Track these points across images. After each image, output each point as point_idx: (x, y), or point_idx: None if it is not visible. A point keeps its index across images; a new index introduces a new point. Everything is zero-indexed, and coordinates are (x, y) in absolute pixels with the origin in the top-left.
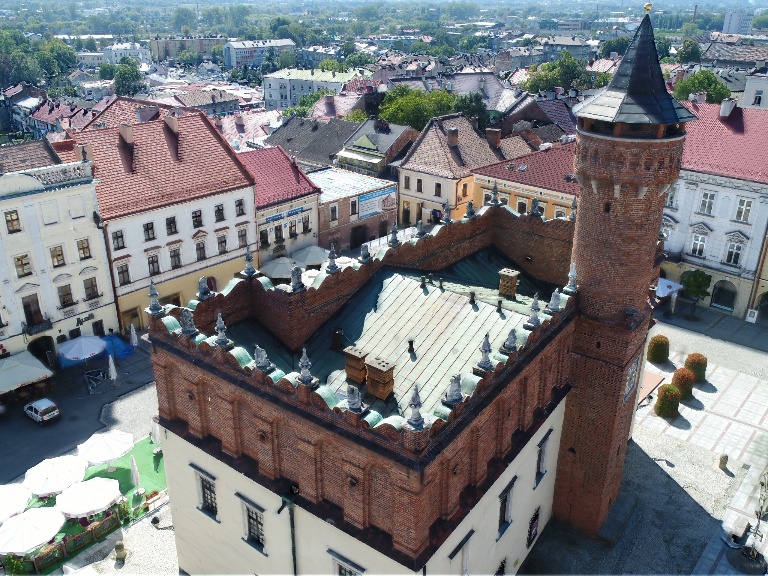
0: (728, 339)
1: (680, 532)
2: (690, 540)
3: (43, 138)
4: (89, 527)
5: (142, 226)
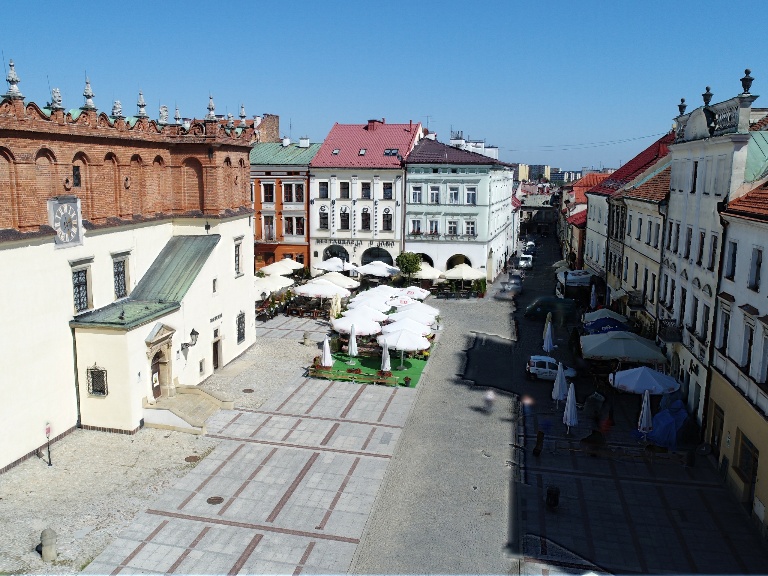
0: None
1: None
2: None
3: None
4: (346, 339)
5: (753, 251)
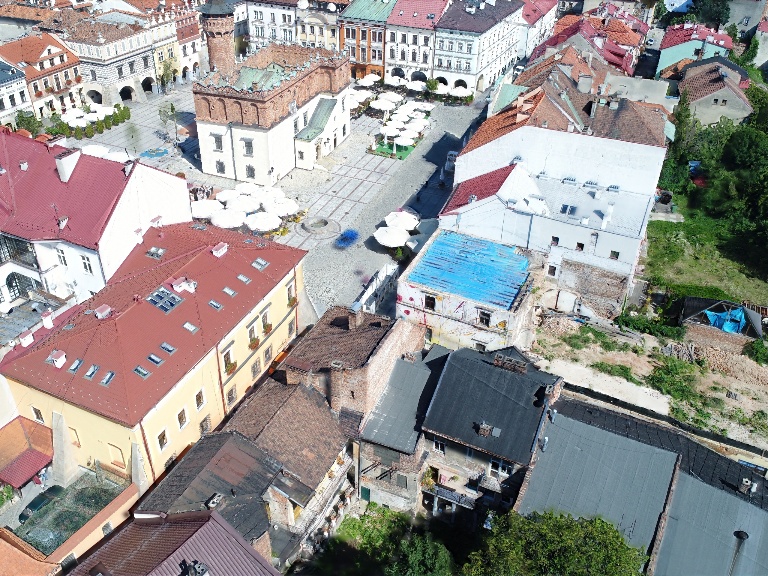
0: None
1: (198, 153)
2: (195, 152)
3: (541, 87)
4: None
5: None
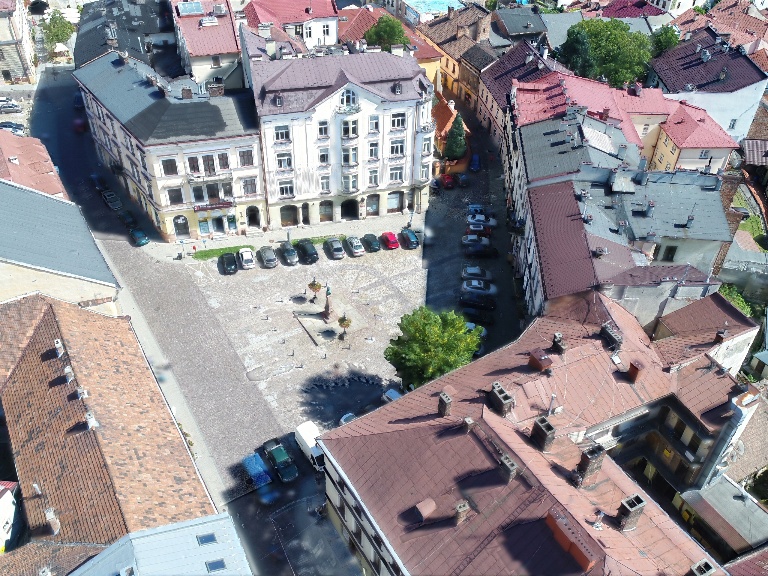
0: None
1: None
2: None
3: None
4: None
5: None
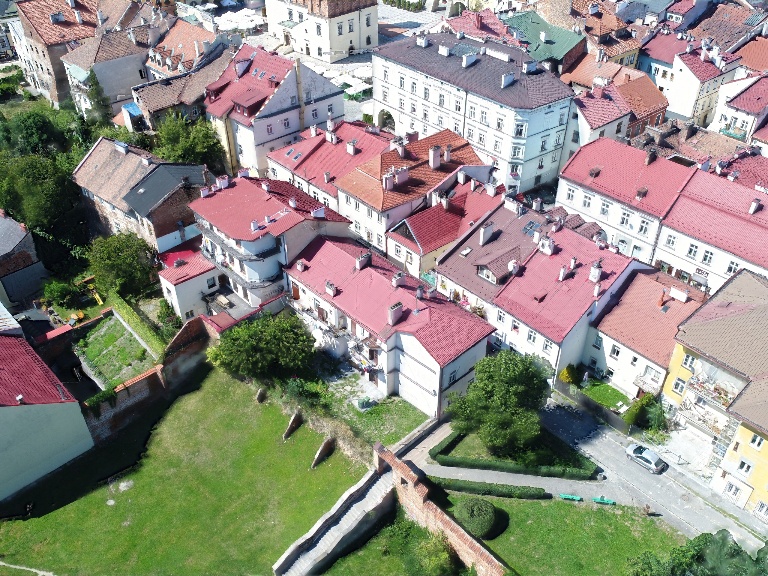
0: (260, 7)
1: None
2: None
3: (145, 3)
4: None
5: None
